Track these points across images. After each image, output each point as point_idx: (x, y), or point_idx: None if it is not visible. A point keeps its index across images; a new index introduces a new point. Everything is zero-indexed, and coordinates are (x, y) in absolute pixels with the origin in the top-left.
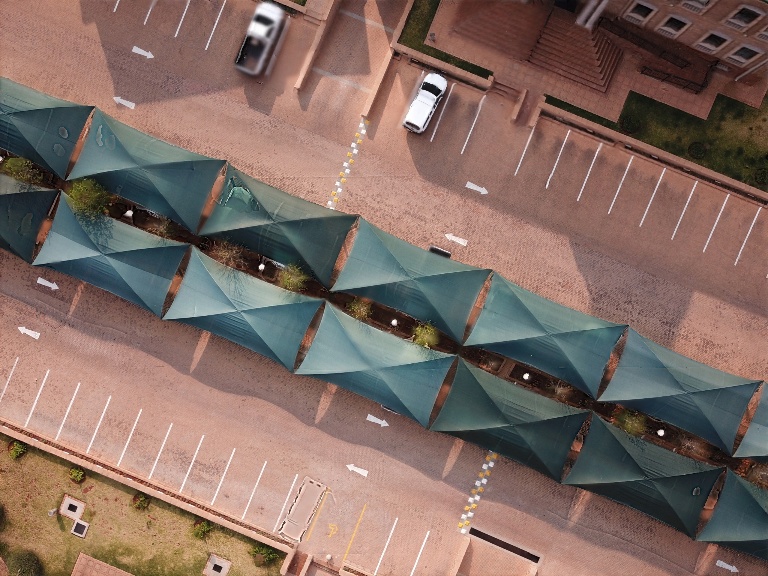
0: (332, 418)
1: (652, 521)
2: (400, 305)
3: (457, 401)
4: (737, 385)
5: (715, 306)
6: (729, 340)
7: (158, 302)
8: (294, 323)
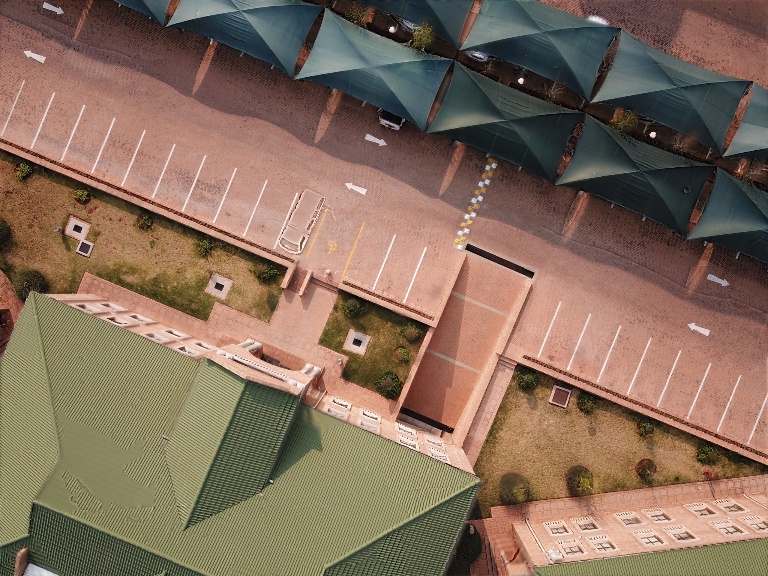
0: (331, 138)
1: (644, 236)
2: (398, 9)
3: (453, 103)
4: (727, 81)
5: (706, 23)
6: (720, 57)
7: (161, 9)
8: (294, 27)
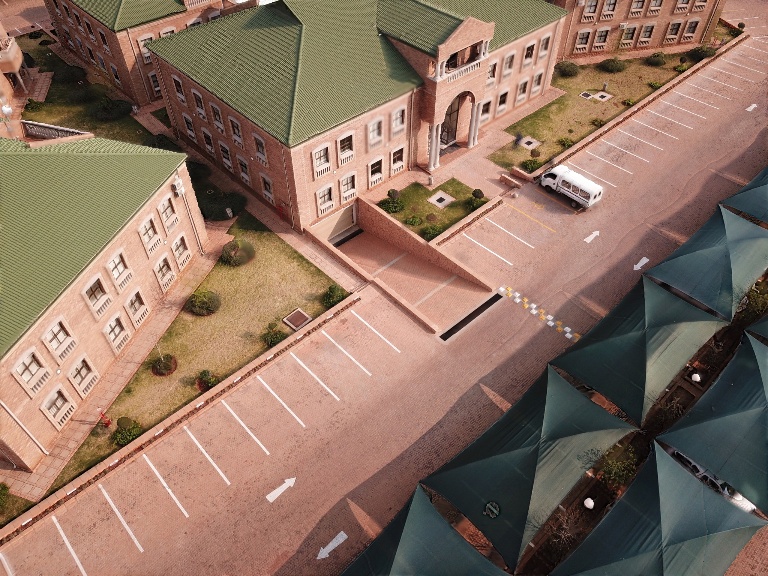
0: (650, 235)
1: None
2: None
3: (676, 302)
4: None
5: None
6: None
7: None
8: None
